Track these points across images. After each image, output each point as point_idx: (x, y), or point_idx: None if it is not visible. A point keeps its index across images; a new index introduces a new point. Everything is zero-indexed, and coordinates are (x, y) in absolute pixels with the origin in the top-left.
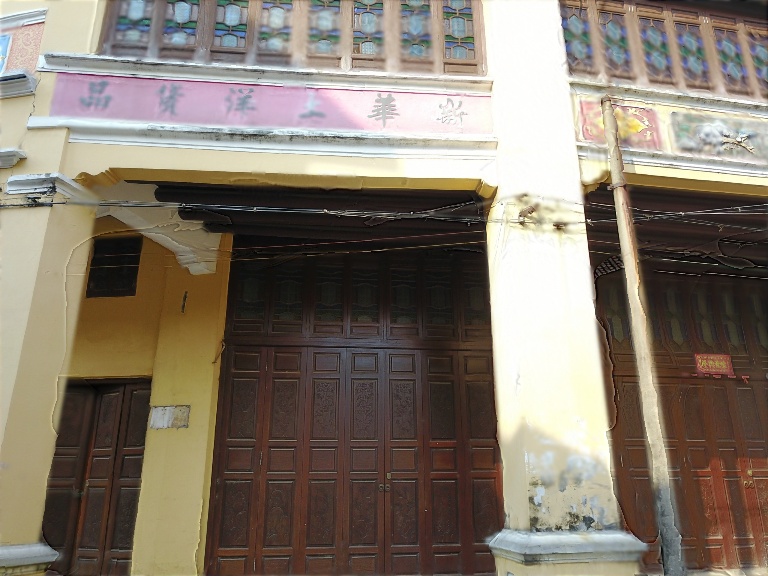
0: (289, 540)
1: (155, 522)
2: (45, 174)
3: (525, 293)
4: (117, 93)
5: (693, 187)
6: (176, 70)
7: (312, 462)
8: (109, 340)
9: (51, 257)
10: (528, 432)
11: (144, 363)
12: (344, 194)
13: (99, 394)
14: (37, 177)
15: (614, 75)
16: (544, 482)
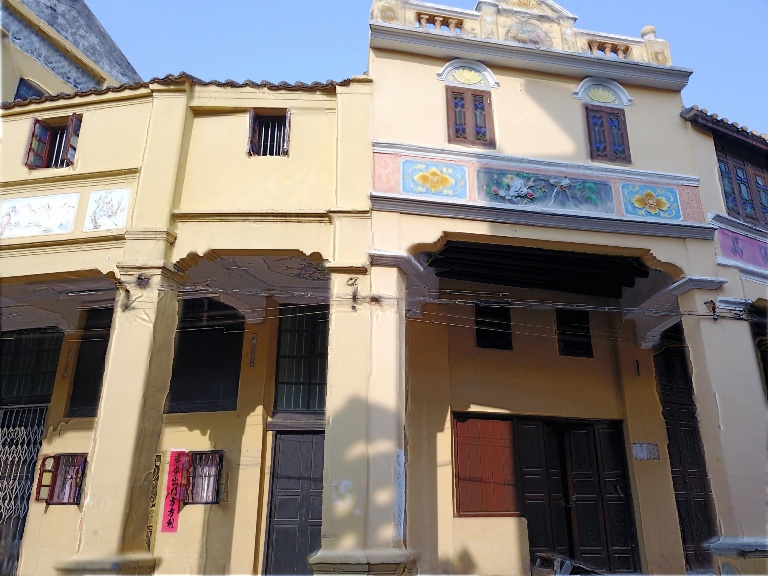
0: (710, 539)
1: (656, 527)
2: (745, 300)
3: None
4: (744, 246)
5: None
6: (764, 235)
7: (709, 486)
8: (585, 390)
9: None
10: None
11: (611, 410)
12: None
13: (567, 430)
14: (740, 301)
15: None
16: None
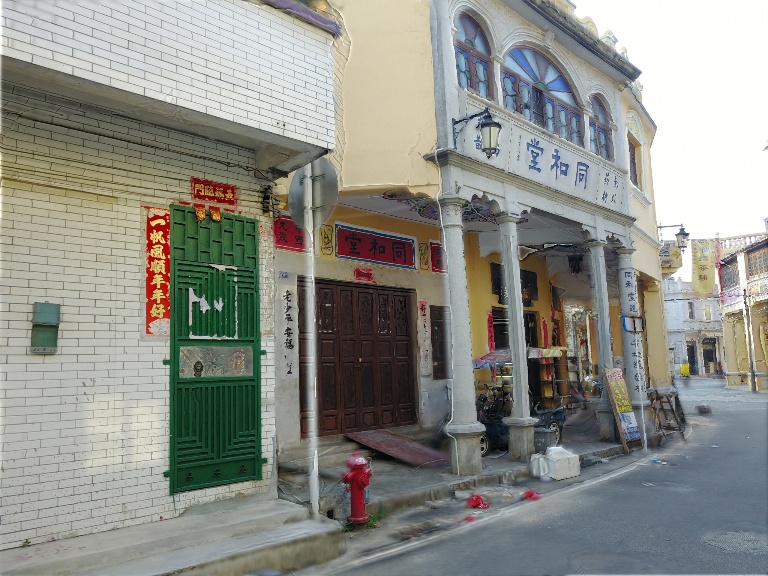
0: None
1: None
2: None
3: None
4: None
5: (763, 302)
6: None
7: None
8: None
9: None
10: None
11: None
12: (738, 314)
13: None
14: None
15: (756, 274)
16: None
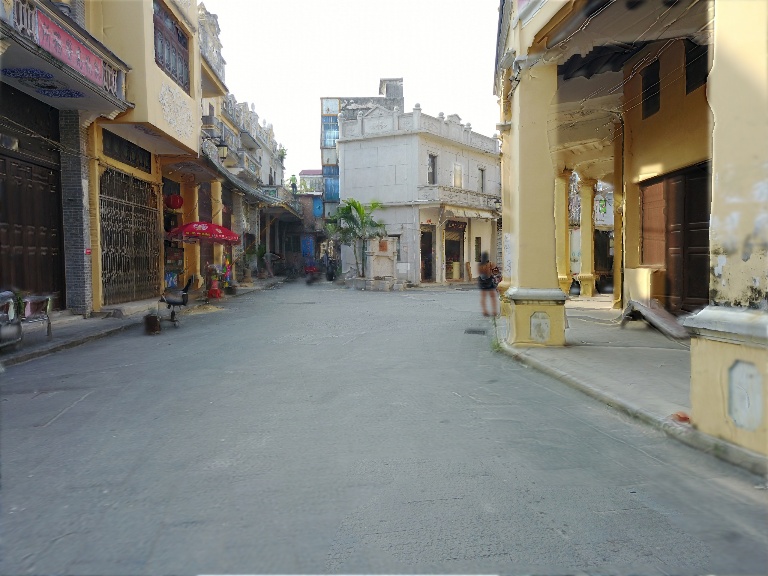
0: None
1: None
2: None
3: (724, 2)
4: None
5: None
6: None
7: None
8: (697, 129)
9: (523, 116)
10: (714, 192)
11: None
12: None
13: None
14: (513, 64)
15: None
16: (726, 250)
